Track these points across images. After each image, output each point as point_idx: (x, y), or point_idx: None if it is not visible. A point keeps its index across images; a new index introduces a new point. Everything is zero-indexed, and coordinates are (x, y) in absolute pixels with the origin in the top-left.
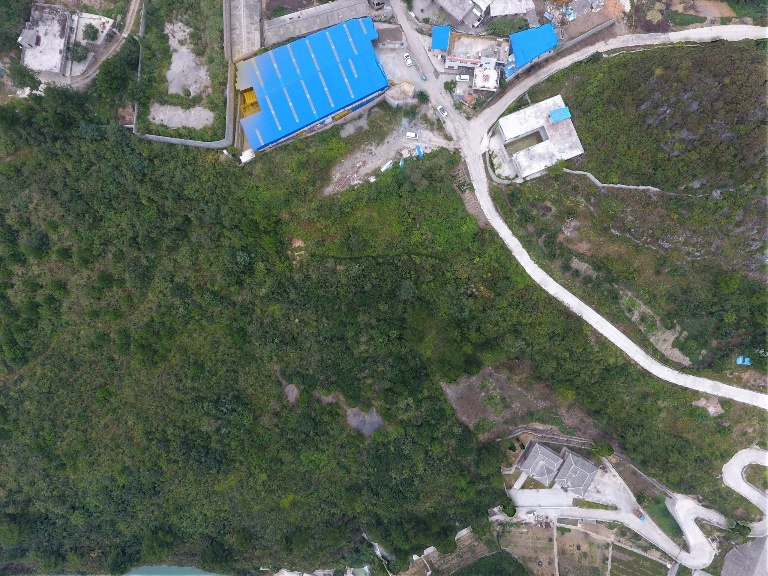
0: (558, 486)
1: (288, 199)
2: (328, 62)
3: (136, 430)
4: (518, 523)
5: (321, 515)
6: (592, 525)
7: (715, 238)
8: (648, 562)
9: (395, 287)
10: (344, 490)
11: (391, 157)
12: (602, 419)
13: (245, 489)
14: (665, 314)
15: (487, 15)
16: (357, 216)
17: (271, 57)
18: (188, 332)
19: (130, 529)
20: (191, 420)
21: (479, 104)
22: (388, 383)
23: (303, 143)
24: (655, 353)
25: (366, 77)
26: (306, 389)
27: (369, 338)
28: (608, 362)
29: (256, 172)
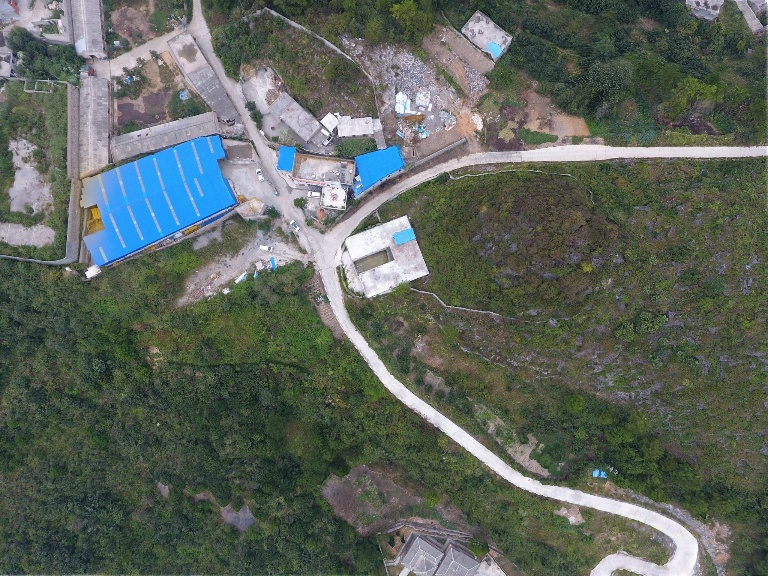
0: None
1: (138, 312)
2: (173, 181)
3: None
4: None
5: None
6: None
7: (560, 360)
8: None
9: (256, 393)
10: None
11: (246, 269)
12: (471, 522)
13: None
14: (520, 427)
15: (336, 135)
16: (212, 326)
17: (117, 174)
18: (46, 436)
19: None
20: (56, 519)
21: (330, 220)
22: (255, 484)
23: (151, 258)
24: (512, 465)
25: (212, 196)
26: (174, 489)
27: (234, 441)
28: (466, 473)
29: (103, 287)
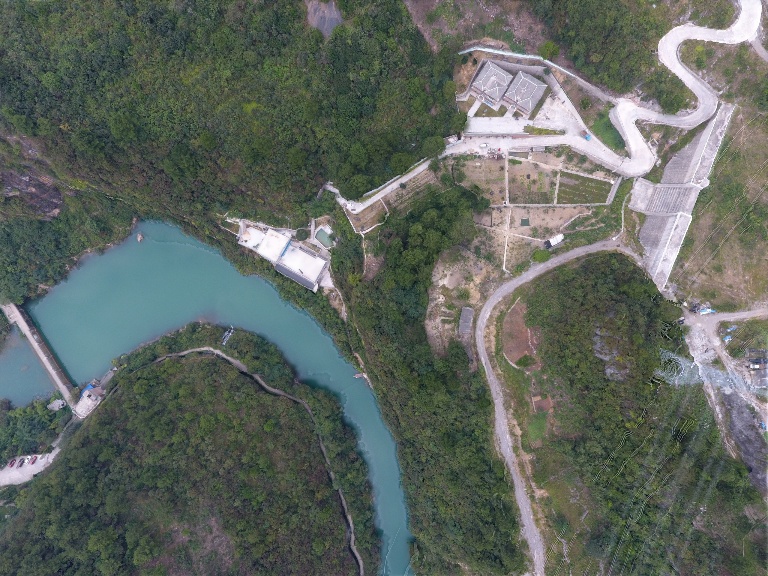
0: (510, 114)
1: None
2: None
3: None
4: (472, 155)
5: (283, 135)
6: (542, 156)
7: None
8: (593, 183)
9: None
10: (305, 106)
11: None
12: None
13: (210, 81)
14: None
15: None
16: None
17: None
18: None
19: (99, 112)
20: None
21: None
22: None
23: None
24: None
25: None
26: None
27: None
28: None
29: None
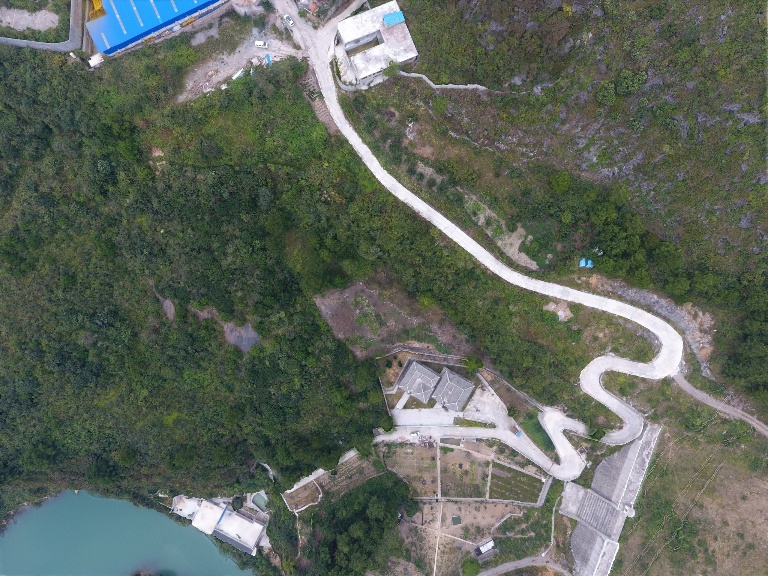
0: (439, 406)
1: (140, 105)
2: None
3: (10, 341)
4: (403, 443)
5: (208, 435)
6: (473, 444)
7: (545, 137)
8: (525, 478)
9: (255, 197)
10: (229, 409)
11: (242, 66)
12: (464, 329)
13: (126, 404)
14: (509, 218)
15: None
16: (212, 124)
17: None
18: (56, 242)
19: (12, 443)
20: (67, 333)
21: (322, 12)
22: (257, 295)
23: (151, 49)
24: (502, 256)
25: None
26: (179, 302)
27: (235, 249)
28: (457, 266)
29: (106, 77)
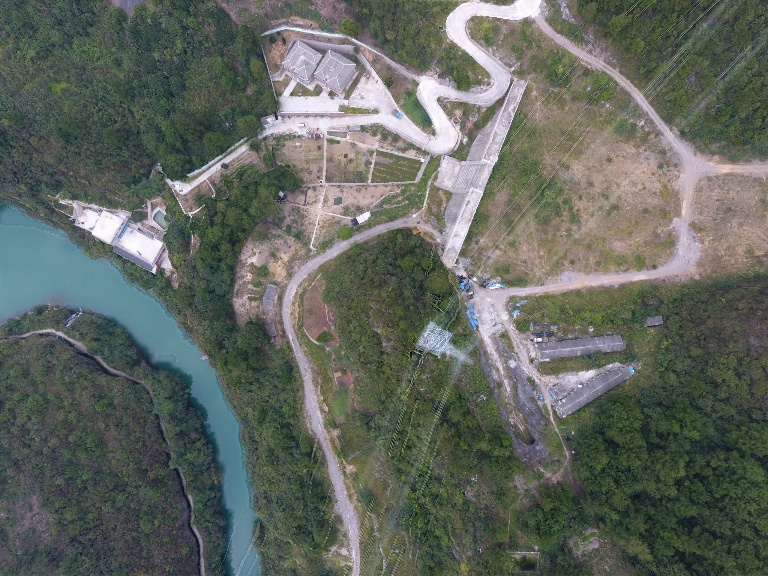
0: (325, 94)
1: None
2: None
3: None
4: (291, 135)
5: (99, 115)
6: (359, 135)
7: None
8: (406, 161)
9: None
10: None
11: None
12: None
13: (12, 60)
14: None
15: None
16: None
17: None
18: None
19: None
20: None
21: None
22: None
23: None
24: None
25: None
26: None
27: None
28: None
29: None
